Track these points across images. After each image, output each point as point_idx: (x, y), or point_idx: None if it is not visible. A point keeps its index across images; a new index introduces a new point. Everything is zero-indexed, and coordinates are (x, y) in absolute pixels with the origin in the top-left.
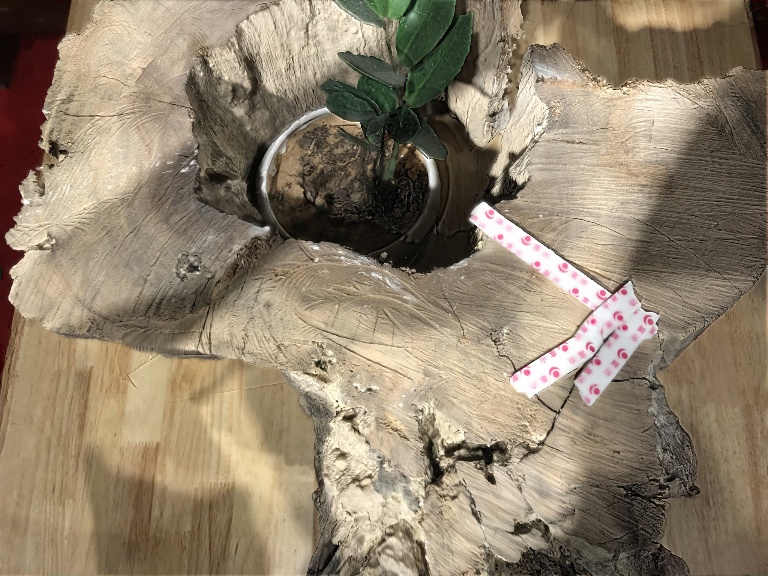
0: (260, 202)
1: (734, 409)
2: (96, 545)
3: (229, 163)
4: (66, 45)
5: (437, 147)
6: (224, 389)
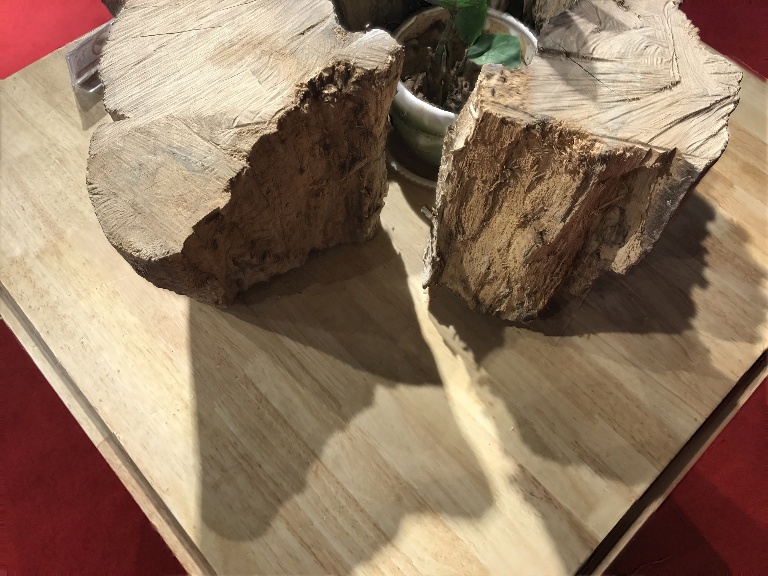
0: None
1: (72, 229)
2: None
3: None
4: None
5: None
6: None
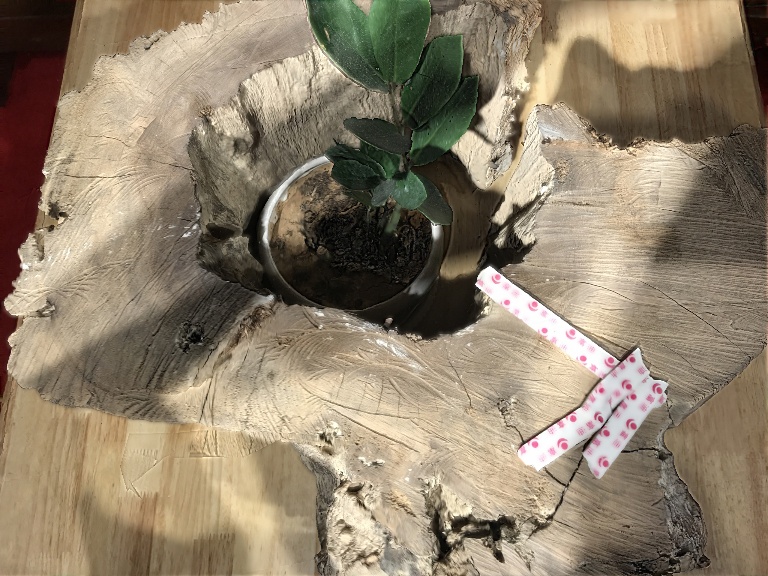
0: (261, 253)
1: (739, 457)
2: None
3: (231, 216)
4: (66, 103)
5: (442, 209)
6: None
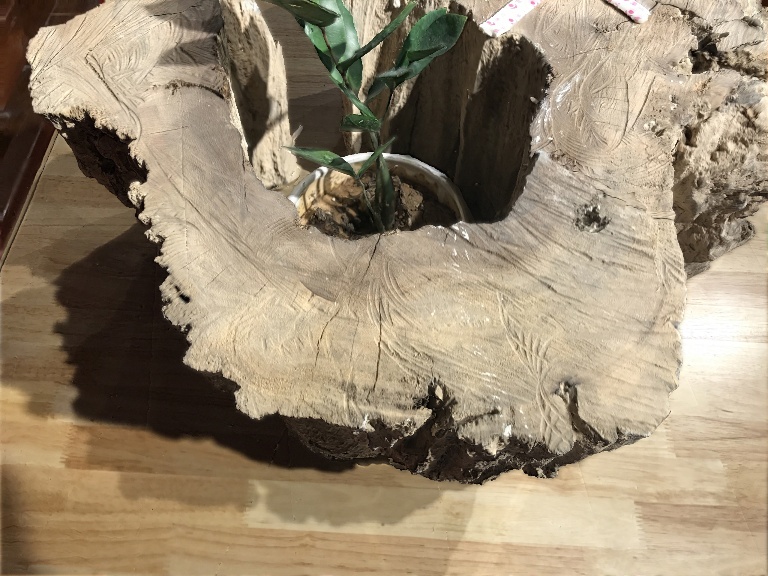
0: None
1: None
2: (764, 571)
3: None
4: (254, 404)
5: None
6: None
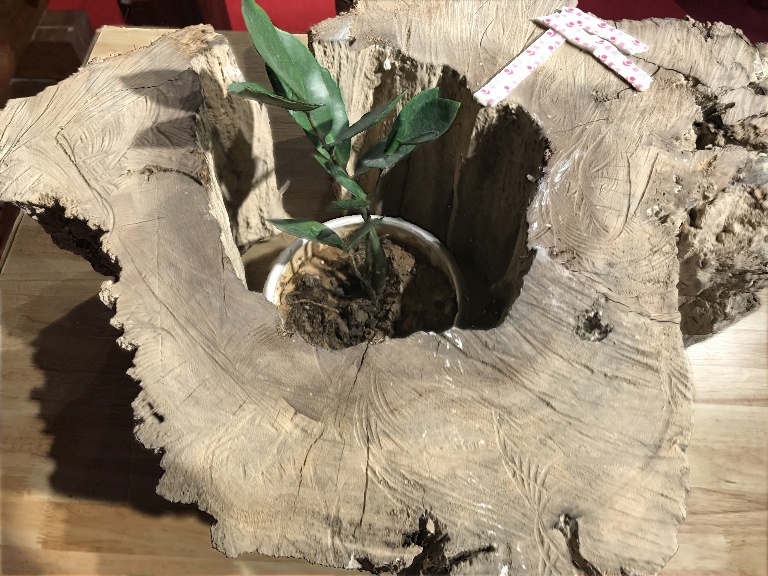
0: None
1: None
2: None
3: None
4: (232, 541)
5: None
6: None
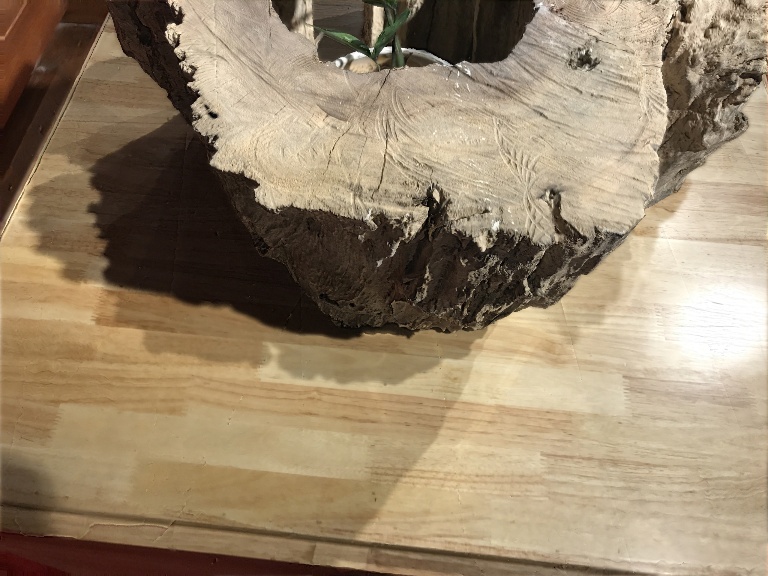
0: None
1: None
2: (742, 440)
3: None
4: (272, 198)
5: None
6: (560, 312)
